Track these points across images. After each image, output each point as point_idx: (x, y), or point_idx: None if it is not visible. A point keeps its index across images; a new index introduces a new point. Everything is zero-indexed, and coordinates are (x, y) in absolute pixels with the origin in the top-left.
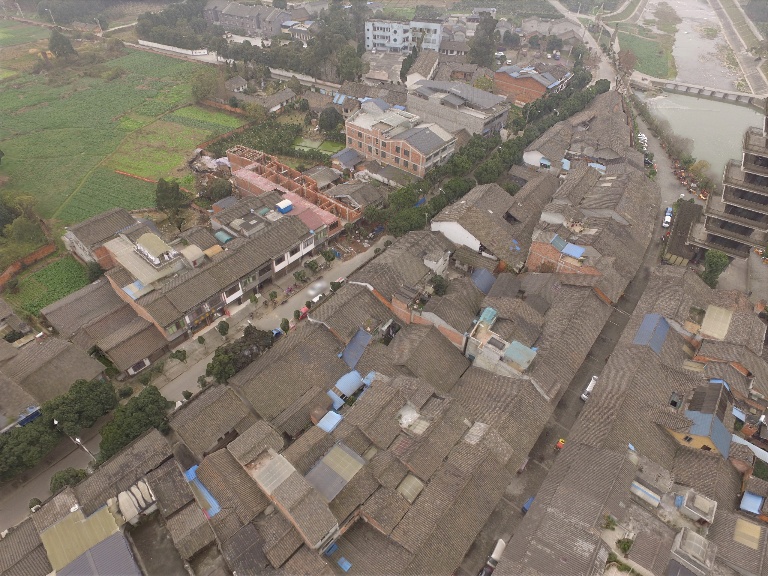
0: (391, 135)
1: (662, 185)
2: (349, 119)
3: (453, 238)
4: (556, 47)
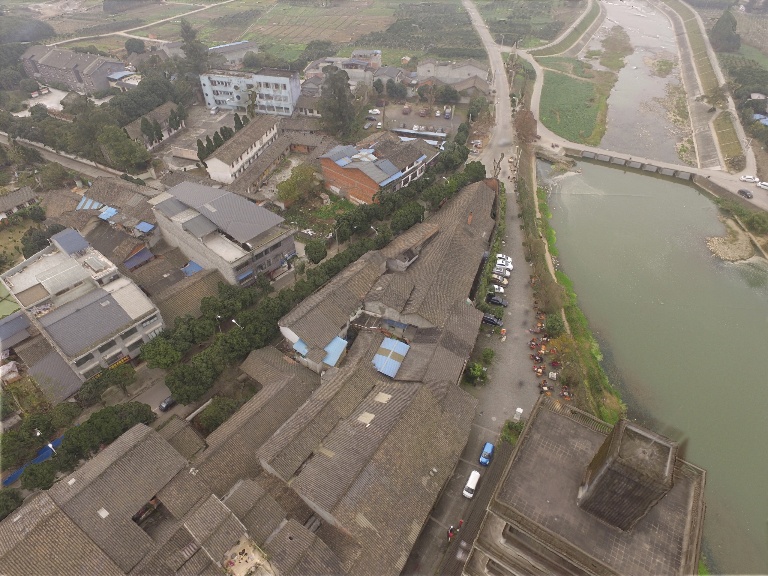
0: (53, 306)
1: (501, 375)
2: (11, 270)
3: None
4: (451, 99)
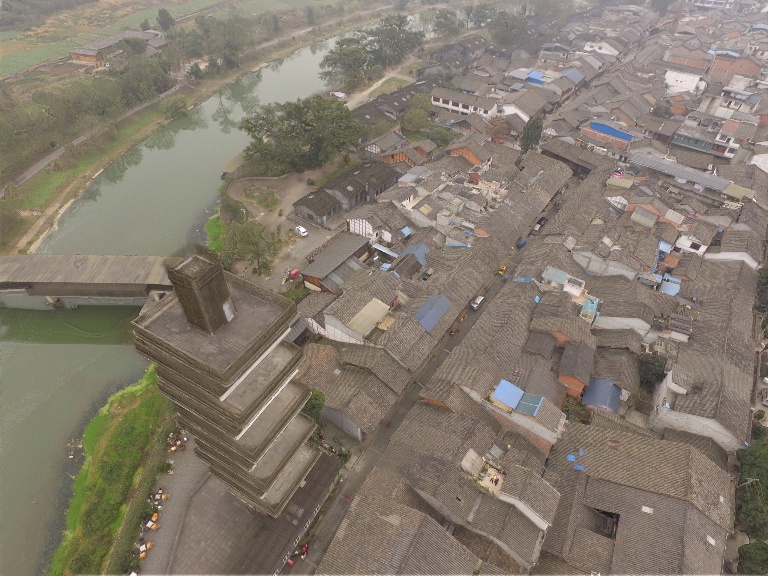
0: None
1: None
2: None
3: None
4: None
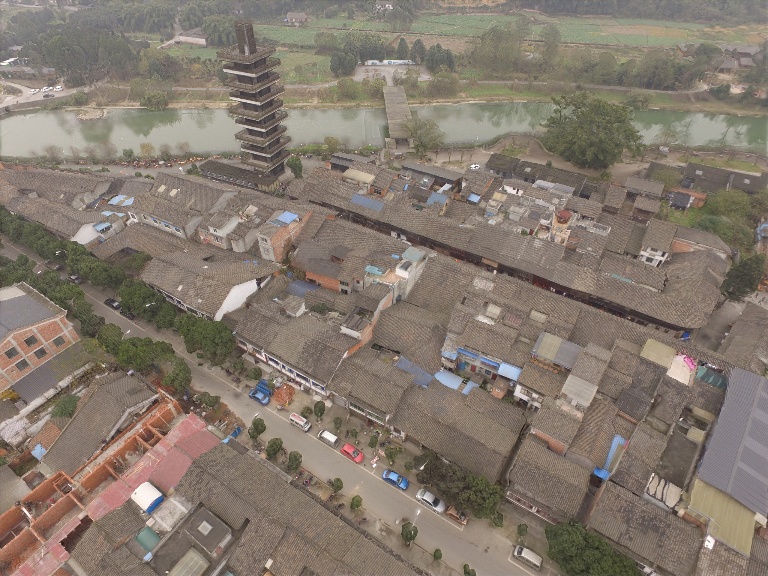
0: None
1: (154, 177)
2: None
3: (237, 305)
4: None
